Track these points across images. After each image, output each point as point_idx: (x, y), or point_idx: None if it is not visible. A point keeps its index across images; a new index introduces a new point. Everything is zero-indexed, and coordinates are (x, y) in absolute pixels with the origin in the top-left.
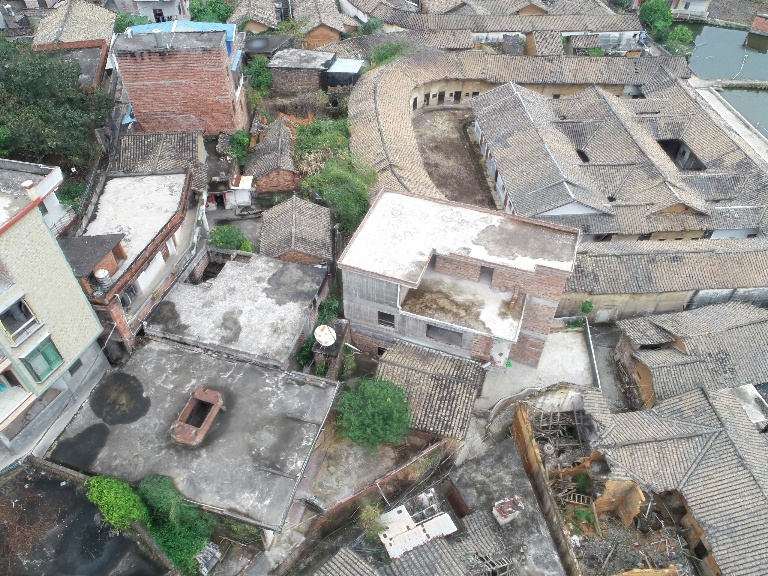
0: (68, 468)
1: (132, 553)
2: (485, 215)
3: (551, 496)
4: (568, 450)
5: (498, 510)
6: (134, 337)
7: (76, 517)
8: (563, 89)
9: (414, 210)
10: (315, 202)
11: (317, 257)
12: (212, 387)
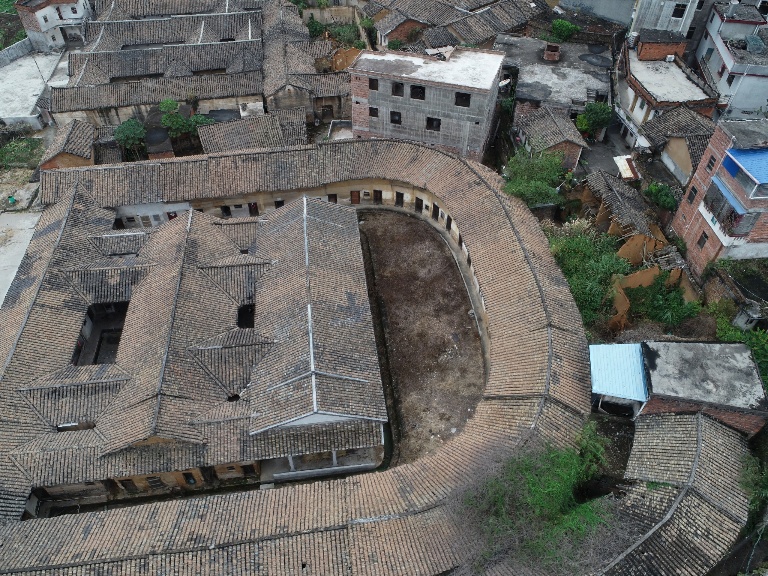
0: None
1: None
2: None
3: None
4: None
5: None
6: None
7: None
8: None
9: (464, 82)
10: (555, 186)
11: None
12: (553, 63)
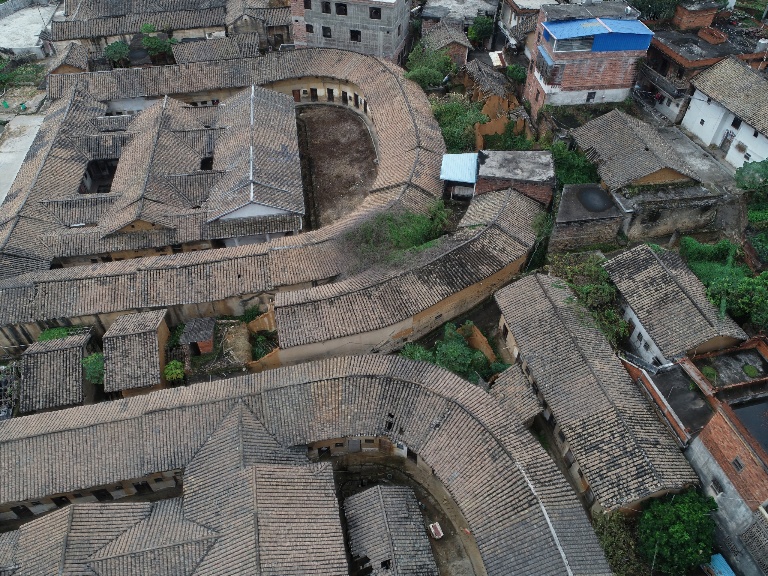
0: None
1: None
2: None
3: None
4: None
5: None
6: None
7: None
8: None
9: None
10: None
11: None
12: None
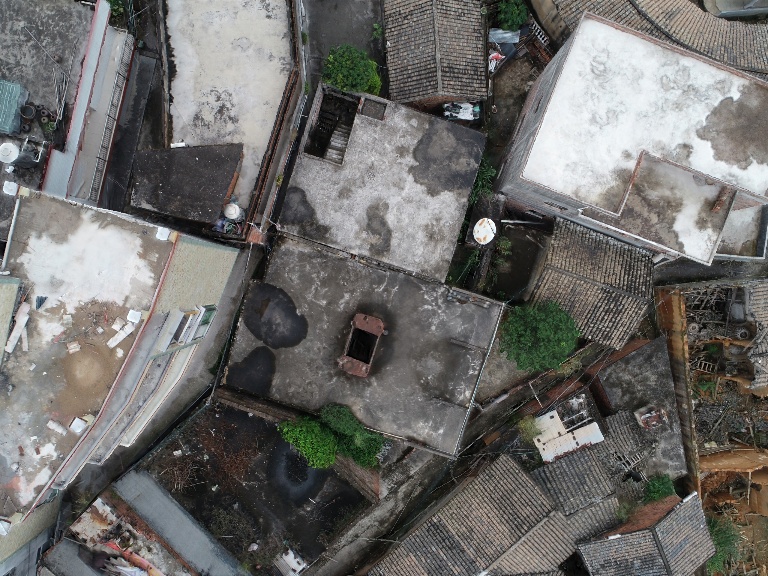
0: (254, 408)
1: (332, 478)
2: (723, 76)
3: (689, 393)
4: (711, 327)
5: (644, 423)
6: (265, 233)
7: (274, 446)
8: None
9: (624, 63)
10: None
11: (469, 98)
12: (368, 304)
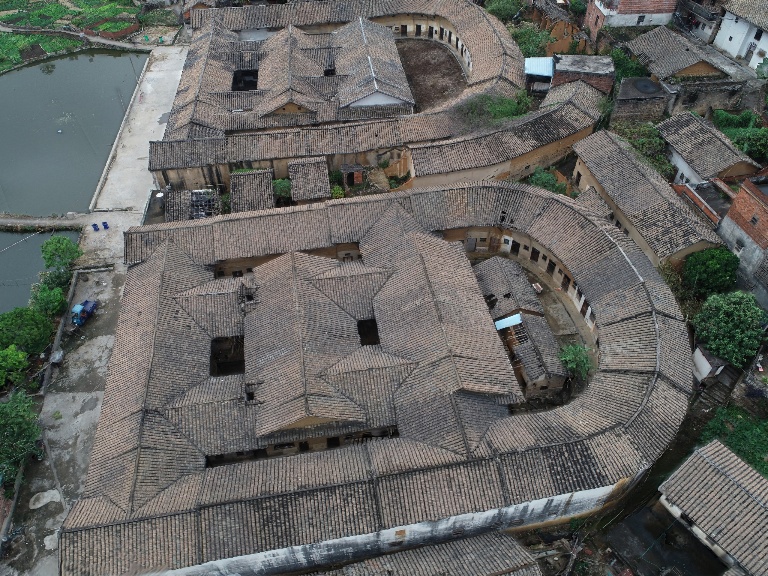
0: None
1: None
2: None
3: None
4: None
5: None
6: None
7: None
8: None
9: None
10: None
11: None
12: None
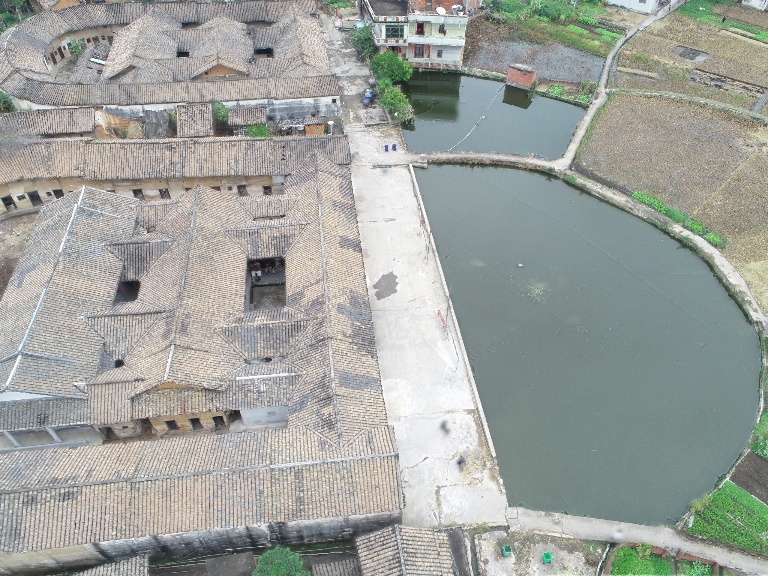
0: None
1: None
2: None
3: None
4: None
5: None
6: None
7: None
8: (194, 182)
9: None
10: None
11: None
12: None
